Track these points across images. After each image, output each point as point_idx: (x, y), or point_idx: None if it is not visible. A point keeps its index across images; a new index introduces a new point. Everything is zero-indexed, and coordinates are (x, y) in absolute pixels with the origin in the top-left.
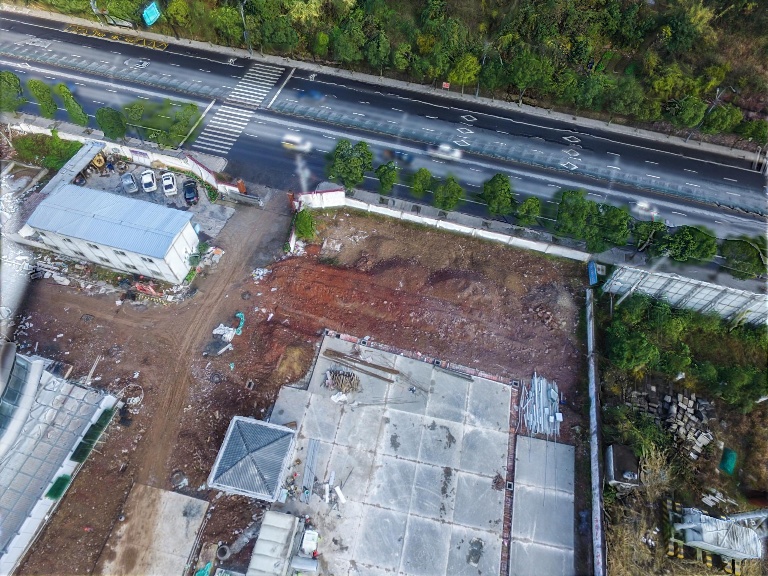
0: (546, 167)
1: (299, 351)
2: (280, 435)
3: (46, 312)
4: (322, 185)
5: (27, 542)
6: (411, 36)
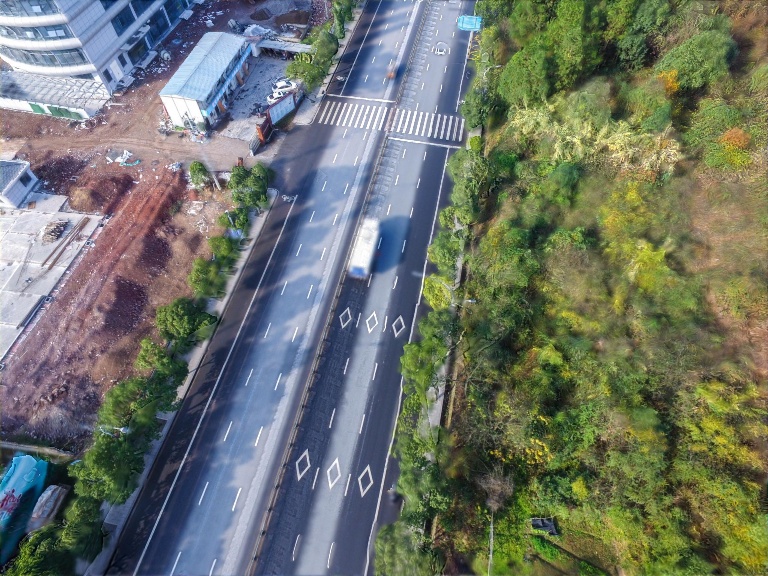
0: (296, 427)
1: (87, 198)
2: (1, 186)
3: (169, 75)
4: (273, 191)
5: (15, 108)
6: (499, 221)
